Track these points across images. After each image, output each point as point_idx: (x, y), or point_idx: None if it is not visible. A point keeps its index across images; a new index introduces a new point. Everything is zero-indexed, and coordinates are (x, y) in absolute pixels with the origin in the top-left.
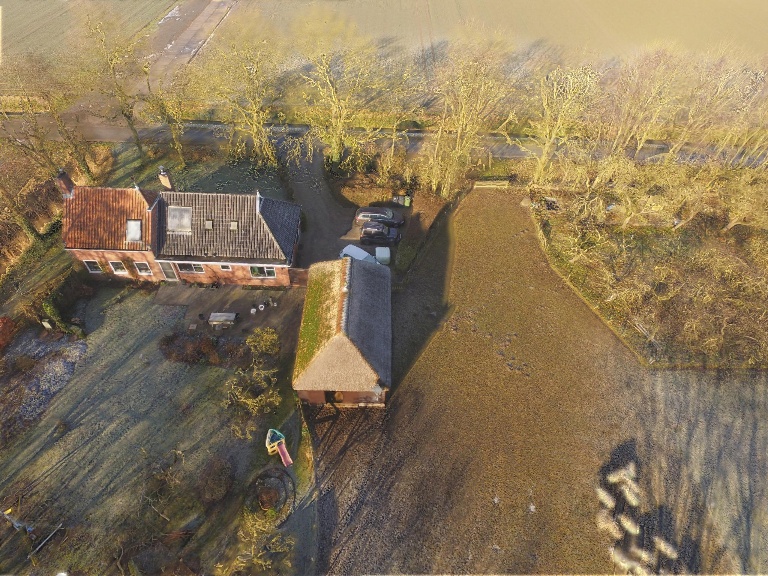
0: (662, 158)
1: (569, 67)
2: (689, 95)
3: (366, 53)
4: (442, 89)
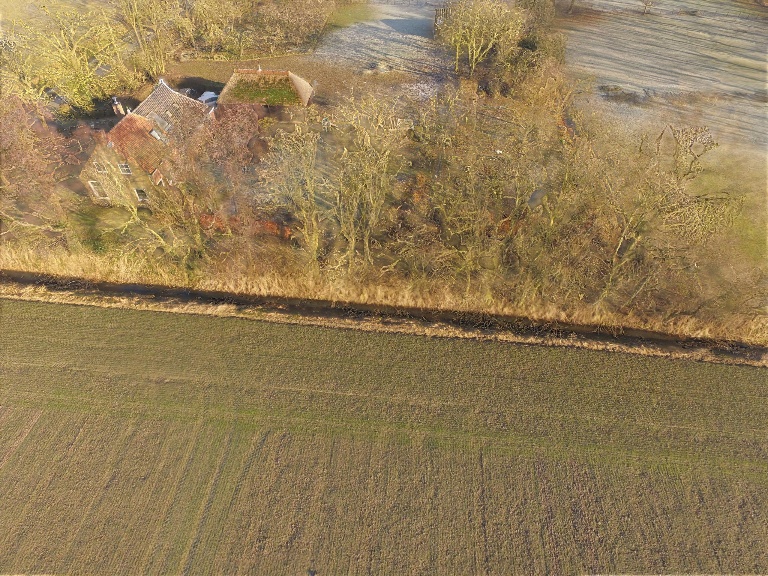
0: None
1: None
2: (105, 1)
3: None
4: (113, 0)
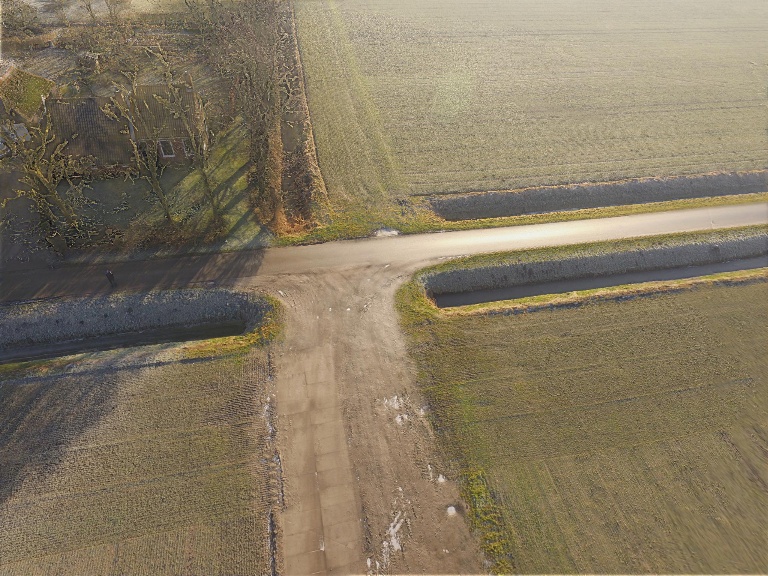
0: None
1: None
2: None
3: None
4: None
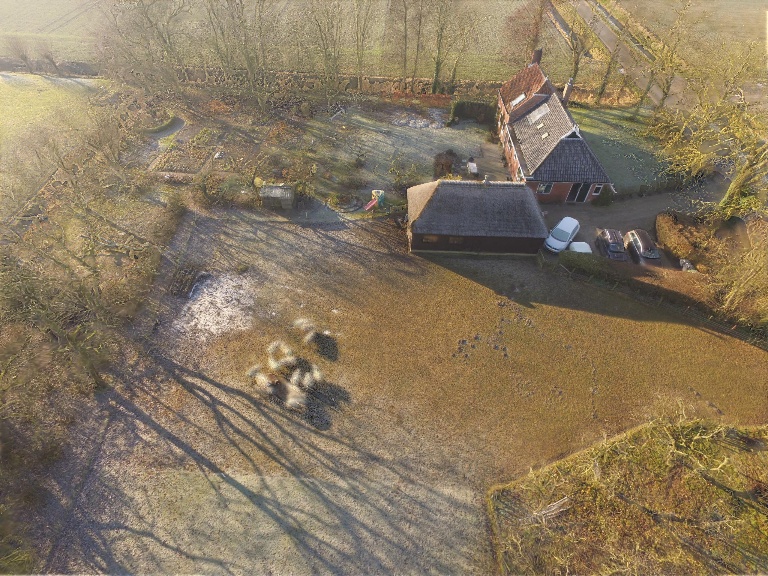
0: None
1: None
2: None
3: None
4: None
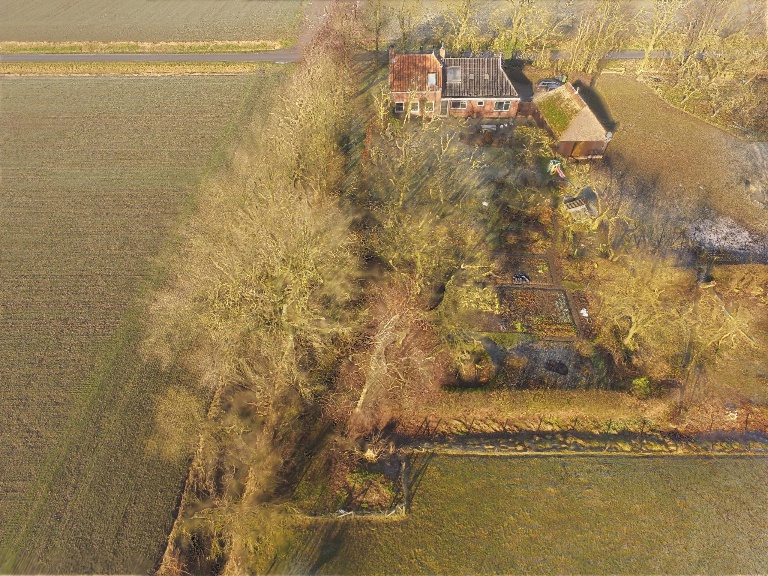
0: (735, 37)
1: (636, 9)
2: None
3: (480, 7)
4: None
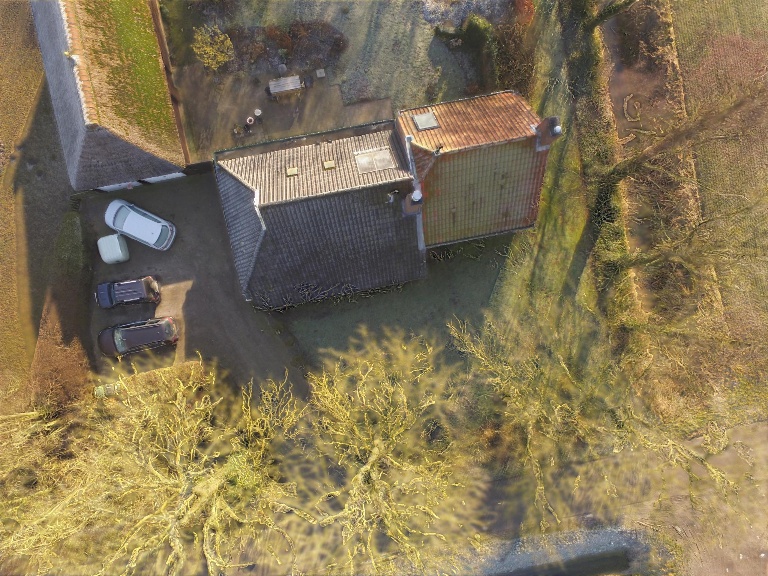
0: None
1: None
2: None
3: None
4: None
